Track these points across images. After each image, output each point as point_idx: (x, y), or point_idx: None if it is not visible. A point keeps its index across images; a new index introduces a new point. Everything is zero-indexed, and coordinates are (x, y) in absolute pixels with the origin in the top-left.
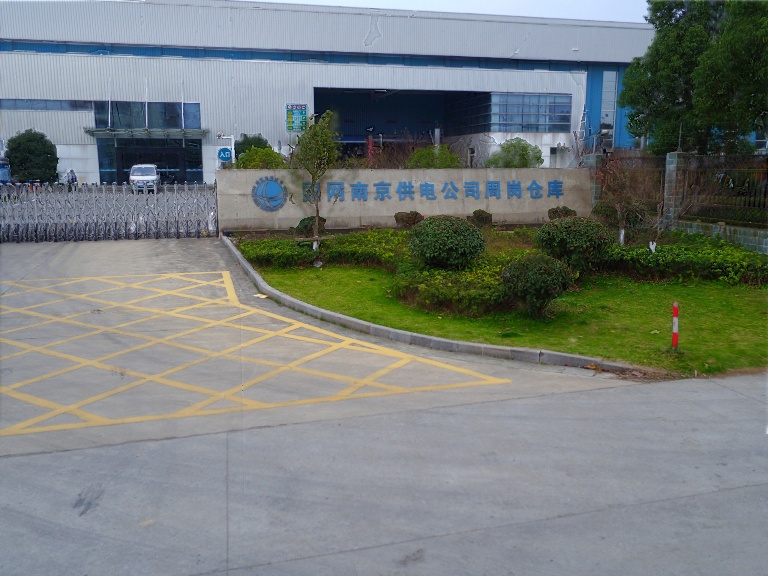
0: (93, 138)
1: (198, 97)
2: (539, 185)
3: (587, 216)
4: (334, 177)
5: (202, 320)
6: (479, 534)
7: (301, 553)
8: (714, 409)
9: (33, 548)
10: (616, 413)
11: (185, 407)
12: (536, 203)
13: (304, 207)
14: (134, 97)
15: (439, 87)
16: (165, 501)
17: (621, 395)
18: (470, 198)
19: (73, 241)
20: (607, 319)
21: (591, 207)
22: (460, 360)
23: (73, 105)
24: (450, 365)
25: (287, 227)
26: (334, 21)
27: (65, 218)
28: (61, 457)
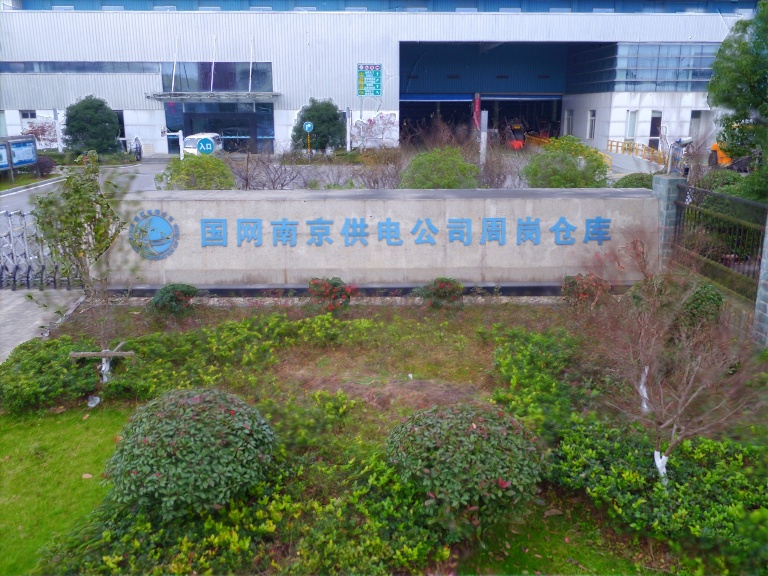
0: (161, 103)
1: (270, 56)
2: (570, 224)
3: None
4: (248, 211)
5: None
6: None
7: None
8: None
9: None
10: None
11: None
12: (563, 252)
13: (203, 254)
14: (202, 57)
15: (551, 37)
16: None
17: None
18: (456, 243)
19: None
20: None
21: (656, 259)
22: None
23: (140, 67)
24: None
25: (178, 282)
26: None
27: None
28: None
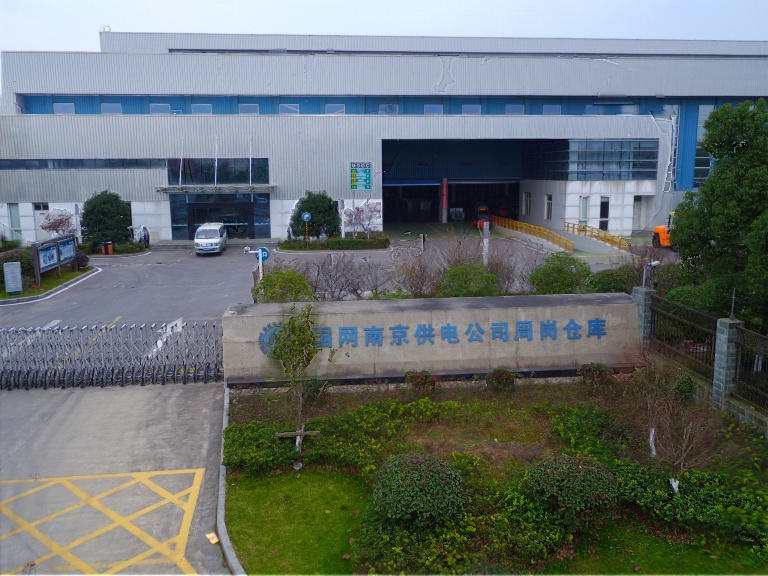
0: (166, 194)
1: (267, 152)
2: (578, 324)
3: None
4: (347, 321)
5: None
6: None
7: None
8: None
9: None
10: None
11: None
12: (574, 344)
13: None
14: (205, 154)
15: (513, 135)
16: None
17: None
18: (497, 340)
19: (80, 388)
20: None
21: (639, 348)
22: None
23: (148, 163)
24: None
25: None
26: (408, 64)
27: (74, 363)
28: None
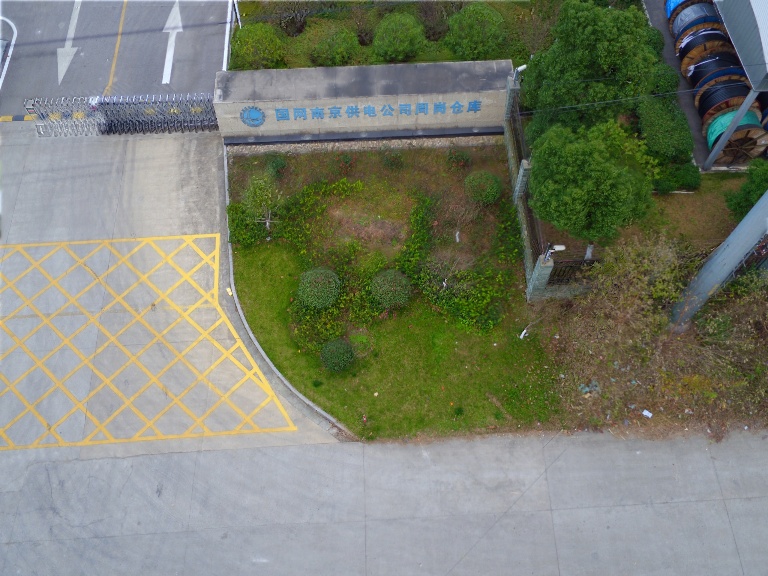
0: None
1: None
2: (461, 104)
3: (499, 123)
4: (298, 105)
5: (198, 330)
6: (242, 528)
7: (203, 527)
8: (345, 472)
9: (149, 511)
10: (314, 467)
11: (186, 430)
12: (457, 116)
13: (278, 124)
14: None
15: None
16: (177, 495)
17: (326, 451)
18: (403, 114)
19: (130, 134)
20: (369, 371)
21: (503, 118)
22: (289, 402)
23: None
24: (283, 408)
25: (267, 135)
26: None
27: None
28: (151, 460)
